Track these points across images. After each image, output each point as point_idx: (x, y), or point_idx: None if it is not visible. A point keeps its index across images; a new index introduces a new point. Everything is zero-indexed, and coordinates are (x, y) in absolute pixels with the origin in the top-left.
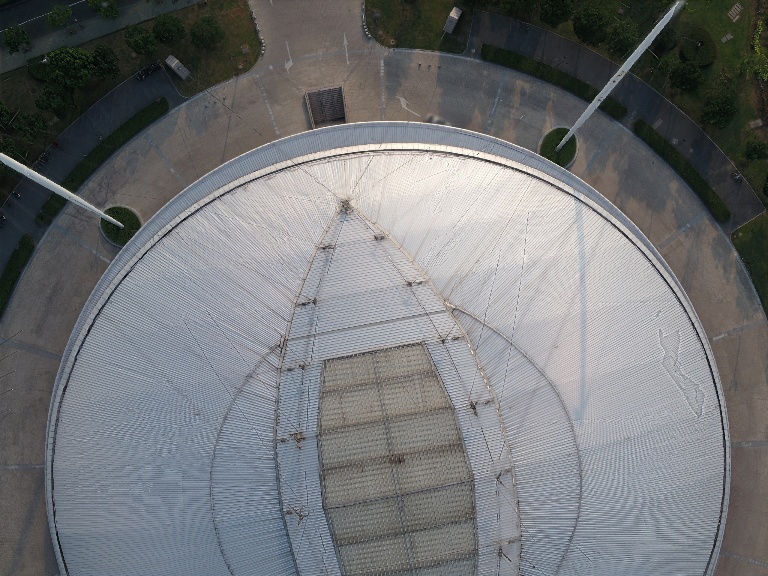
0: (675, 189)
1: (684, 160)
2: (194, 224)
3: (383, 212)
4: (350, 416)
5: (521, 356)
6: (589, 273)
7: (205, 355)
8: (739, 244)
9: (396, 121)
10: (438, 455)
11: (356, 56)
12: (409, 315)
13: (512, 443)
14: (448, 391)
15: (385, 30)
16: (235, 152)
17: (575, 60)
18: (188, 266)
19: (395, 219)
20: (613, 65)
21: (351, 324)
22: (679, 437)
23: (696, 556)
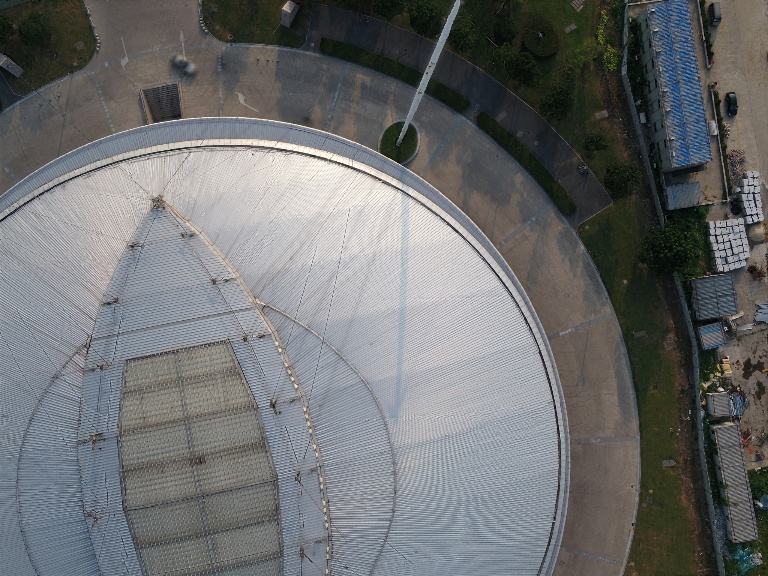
0: (520, 182)
1: (528, 153)
2: (12, 224)
3: (200, 209)
4: (150, 416)
5: (333, 353)
6: (411, 268)
7: (13, 356)
8: (586, 237)
9: (225, 117)
10: (240, 455)
11: (193, 52)
12: (214, 313)
13: (321, 442)
14: (252, 390)
15: (222, 25)
16: (70, 150)
17: (417, 53)
18: (2, 266)
19: (211, 216)
20: (455, 57)
21: (155, 323)
22: (506, 434)
23: (528, 554)
